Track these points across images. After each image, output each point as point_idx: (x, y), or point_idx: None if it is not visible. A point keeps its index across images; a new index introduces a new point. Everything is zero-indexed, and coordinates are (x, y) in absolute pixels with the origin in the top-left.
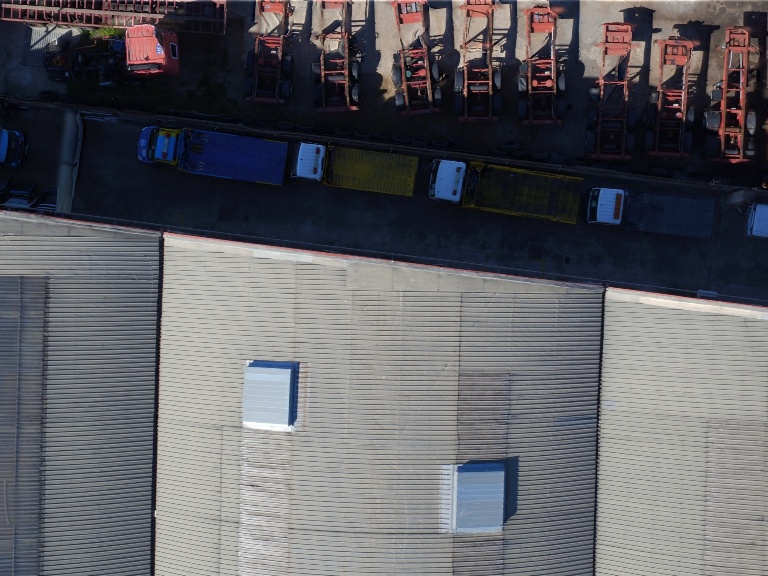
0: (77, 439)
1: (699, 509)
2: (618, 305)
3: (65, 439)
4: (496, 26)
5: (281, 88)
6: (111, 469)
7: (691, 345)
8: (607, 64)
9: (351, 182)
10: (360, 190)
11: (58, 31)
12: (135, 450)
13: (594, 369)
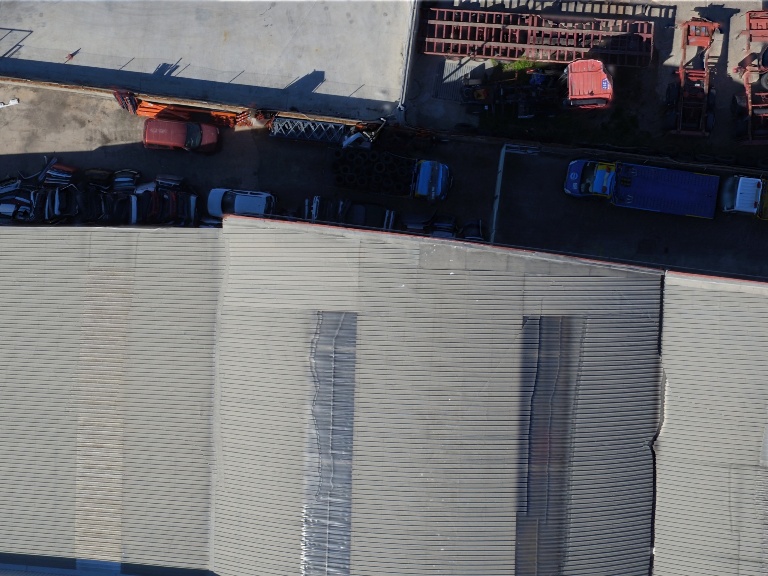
0: (598, 477)
1: None
2: None
3: (589, 477)
4: None
5: (706, 121)
6: (622, 507)
7: None
8: None
9: None
10: None
11: (471, 64)
12: (641, 487)
13: None
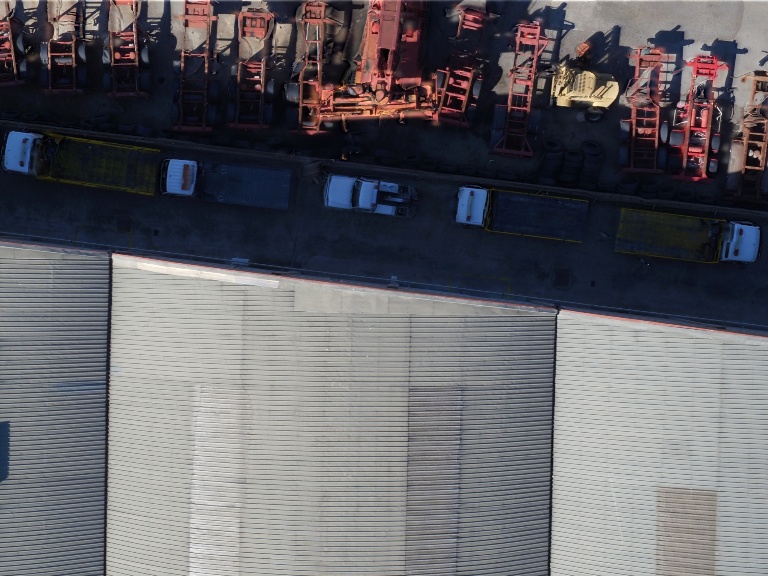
0: None
1: (187, 473)
2: (122, 271)
3: None
4: None
5: None
6: None
7: (174, 309)
8: (198, 37)
9: None
10: None
11: None
12: None
13: (100, 335)
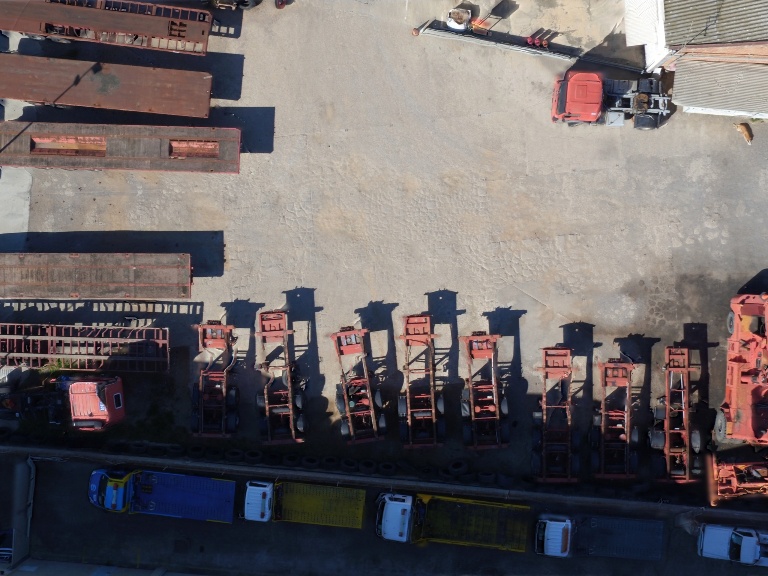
0: None
1: None
2: None
3: None
4: (438, 346)
5: (227, 423)
6: None
7: None
8: (550, 380)
9: (300, 516)
10: (309, 524)
11: (8, 368)
12: None
13: None
